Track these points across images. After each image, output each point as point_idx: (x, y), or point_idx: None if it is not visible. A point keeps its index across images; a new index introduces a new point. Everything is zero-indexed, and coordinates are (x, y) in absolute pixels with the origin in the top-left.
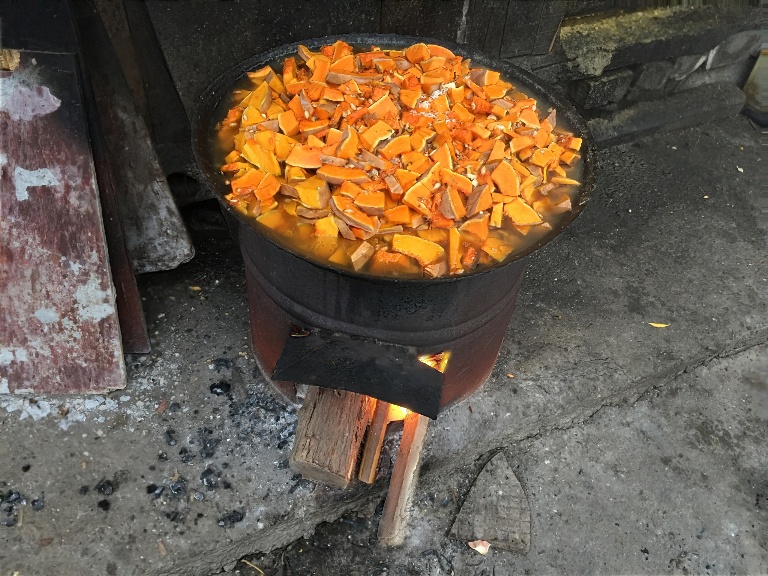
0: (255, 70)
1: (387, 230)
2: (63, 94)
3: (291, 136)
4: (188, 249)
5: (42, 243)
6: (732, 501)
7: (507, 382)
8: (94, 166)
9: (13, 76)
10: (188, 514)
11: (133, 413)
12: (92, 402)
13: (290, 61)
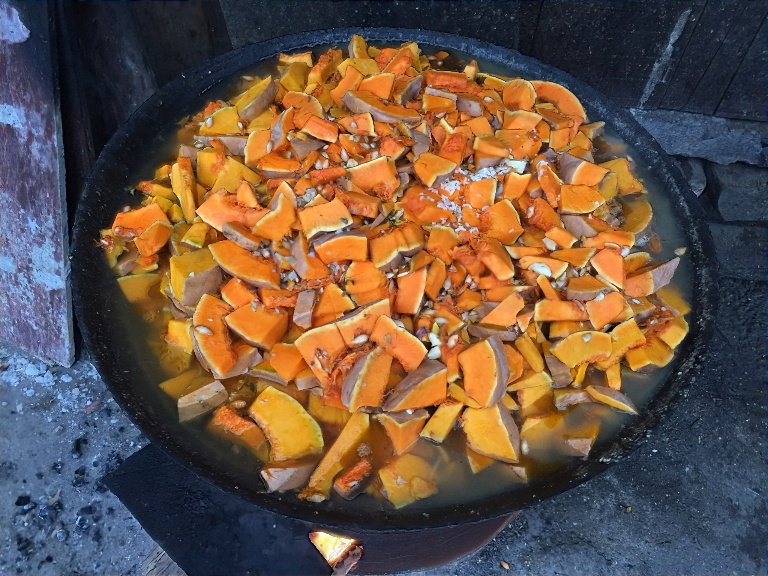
0: (293, 53)
1: (264, 374)
2: (32, 24)
3: (254, 168)
4: None
5: (5, 187)
6: None
7: (495, 573)
8: (62, 120)
9: None
10: (40, 550)
11: (63, 400)
12: (33, 368)
13: (326, 56)
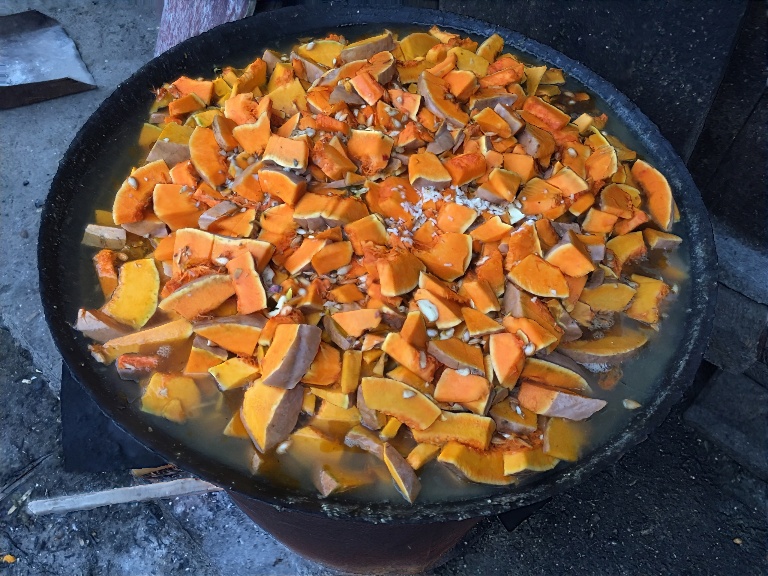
0: (445, 30)
1: None
2: None
3: None
4: None
5: None
6: None
7: None
8: (256, 7)
9: None
10: None
11: None
12: None
13: (454, 39)
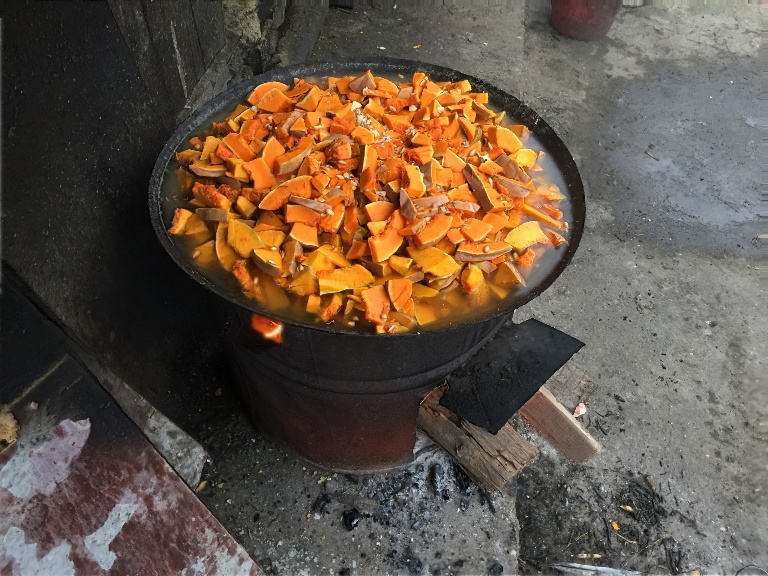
0: (171, 223)
1: None
2: (87, 409)
3: (320, 244)
4: (202, 452)
5: None
6: (613, 250)
7: None
8: None
9: (22, 446)
10: None
11: None
12: None
13: (210, 186)
